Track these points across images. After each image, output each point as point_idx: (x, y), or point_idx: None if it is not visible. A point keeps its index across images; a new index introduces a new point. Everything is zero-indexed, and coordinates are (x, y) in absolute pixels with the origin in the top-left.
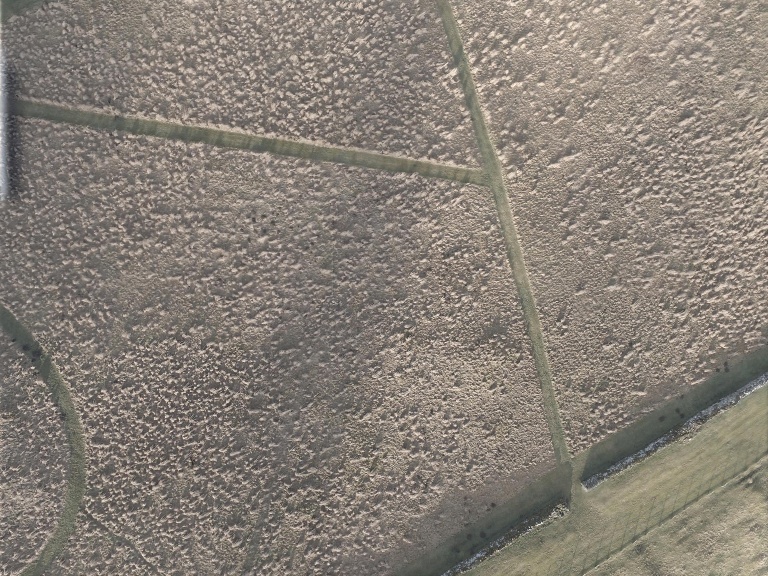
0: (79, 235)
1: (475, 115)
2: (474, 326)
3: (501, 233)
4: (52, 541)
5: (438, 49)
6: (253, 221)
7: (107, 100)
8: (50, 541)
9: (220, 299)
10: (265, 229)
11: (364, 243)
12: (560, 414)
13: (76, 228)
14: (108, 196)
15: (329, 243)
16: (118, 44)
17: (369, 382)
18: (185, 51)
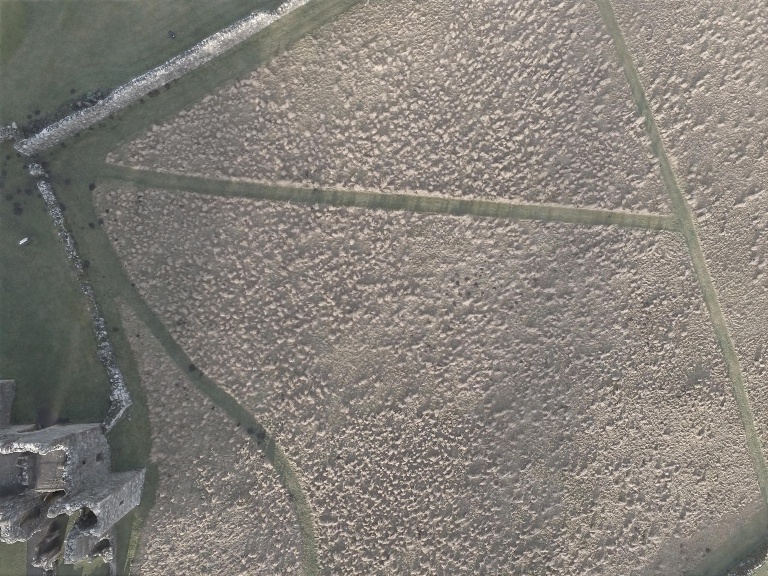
0: (290, 312)
1: (662, 161)
2: (678, 373)
3: (695, 277)
4: None
5: (622, 98)
6: (457, 284)
7: (305, 174)
8: None
9: (432, 366)
10: (469, 291)
11: (567, 298)
12: (763, 453)
13: (286, 305)
14: (314, 270)
15: (532, 301)
16: (312, 117)
17: (582, 437)
18: (378, 119)
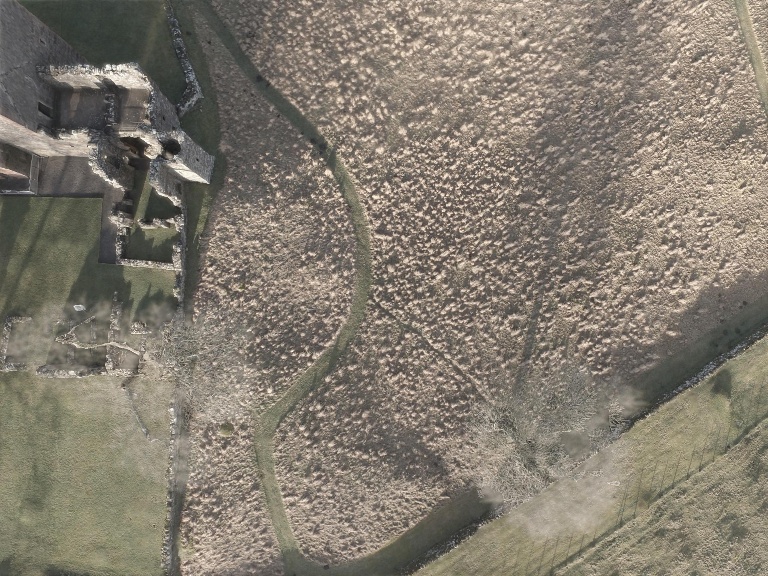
0: (354, 36)
1: None
2: (723, 127)
3: (743, 39)
4: (345, 327)
5: None
6: (514, 24)
7: None
8: (344, 327)
9: (487, 99)
10: (525, 32)
11: (619, 46)
12: None
13: (350, 30)
14: None
15: (586, 46)
16: None
17: (629, 180)
18: None
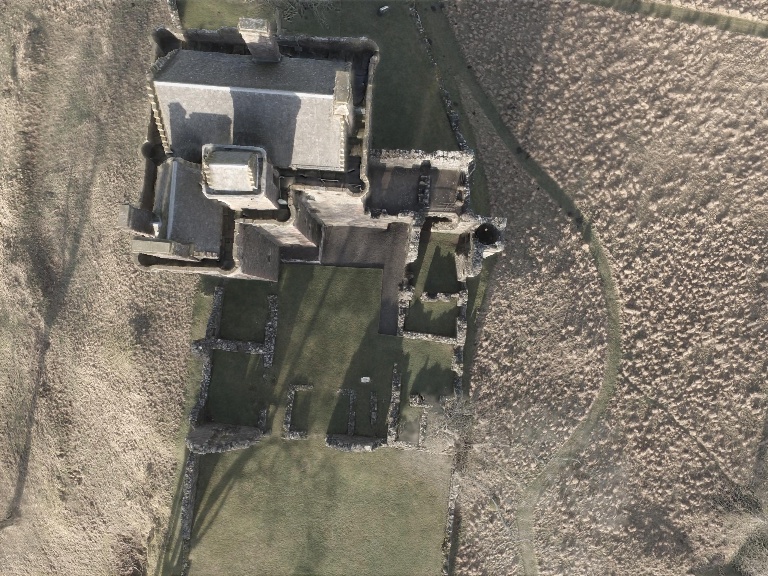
0: (608, 110)
1: None
2: None
3: None
4: (597, 401)
5: None
6: (760, 103)
7: None
8: (595, 401)
9: (732, 177)
10: None
11: None
12: None
13: (604, 104)
14: (631, 75)
15: None
16: None
17: None
18: None
